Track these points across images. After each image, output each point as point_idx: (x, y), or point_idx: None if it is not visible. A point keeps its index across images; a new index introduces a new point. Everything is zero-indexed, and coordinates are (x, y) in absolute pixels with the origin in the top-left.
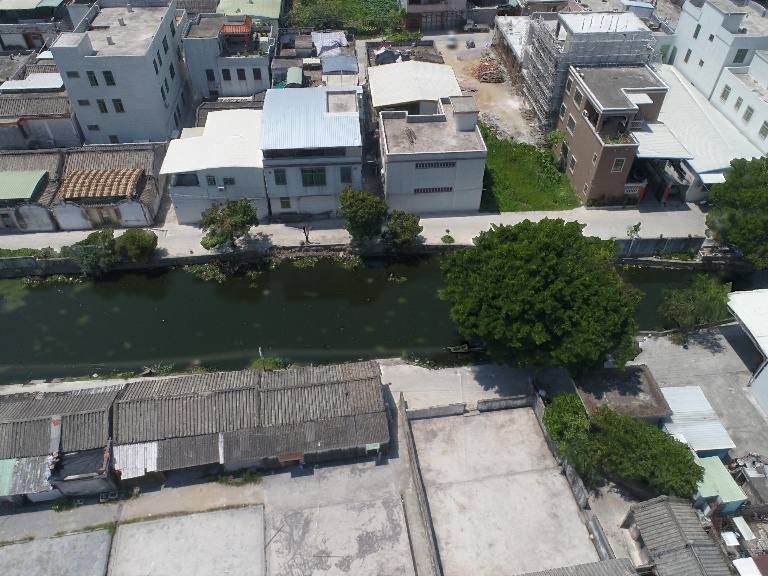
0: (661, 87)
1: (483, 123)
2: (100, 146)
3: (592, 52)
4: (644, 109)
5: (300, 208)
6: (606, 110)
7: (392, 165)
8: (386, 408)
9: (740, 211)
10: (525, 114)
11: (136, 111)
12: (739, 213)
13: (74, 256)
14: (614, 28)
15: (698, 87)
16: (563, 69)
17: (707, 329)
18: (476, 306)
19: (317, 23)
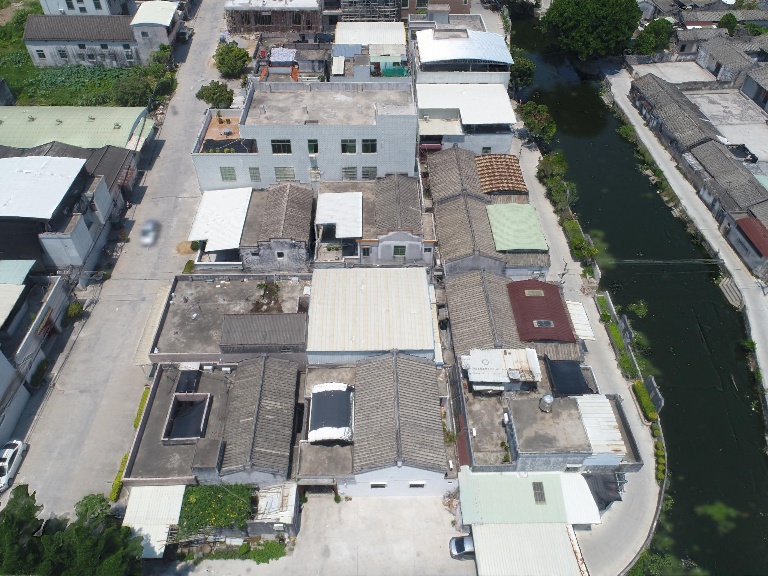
0: None
1: None
2: None
3: None
4: None
5: None
6: None
7: None
8: None
9: None
10: None
11: None
12: None
13: (567, 202)
14: None
15: None
16: None
17: None
18: None
19: None
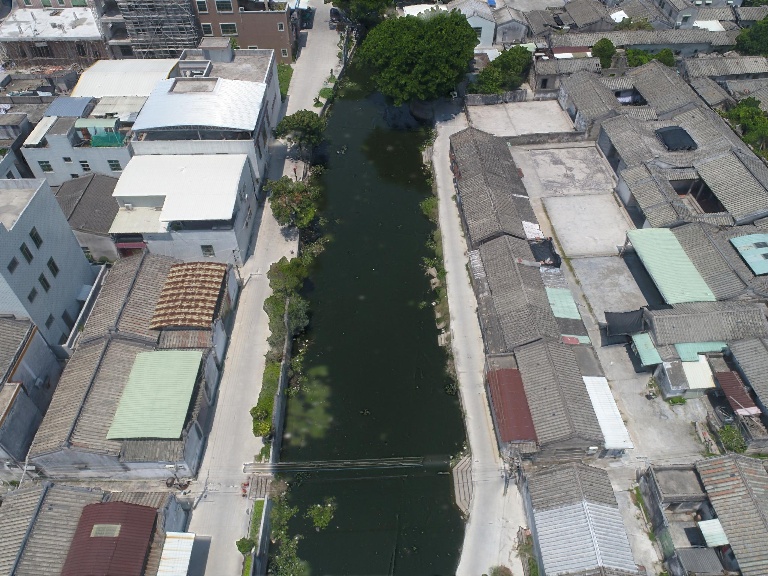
0: None
1: None
2: None
3: None
4: None
5: None
6: None
7: None
8: None
9: None
10: None
11: (64, 259)
12: None
13: (286, 330)
14: None
15: None
16: None
17: None
18: None
19: None
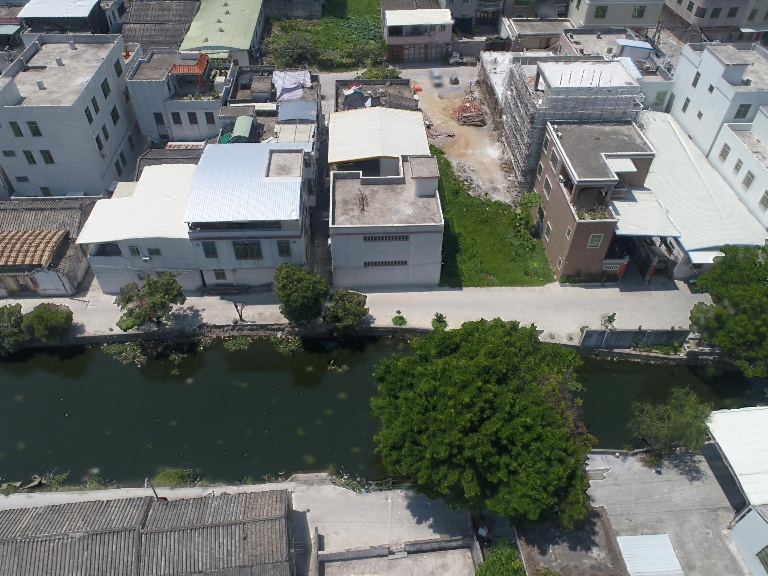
0: (647, 152)
1: (457, 175)
2: (29, 199)
3: (572, 108)
4: (627, 177)
5: (237, 279)
6: (581, 181)
7: (337, 238)
8: (290, 556)
9: (729, 310)
10: (504, 165)
11: (67, 163)
12: (727, 312)
13: None
14: (598, 81)
15: (696, 141)
16: (540, 125)
17: (685, 448)
18: (400, 439)
19: (291, 54)
